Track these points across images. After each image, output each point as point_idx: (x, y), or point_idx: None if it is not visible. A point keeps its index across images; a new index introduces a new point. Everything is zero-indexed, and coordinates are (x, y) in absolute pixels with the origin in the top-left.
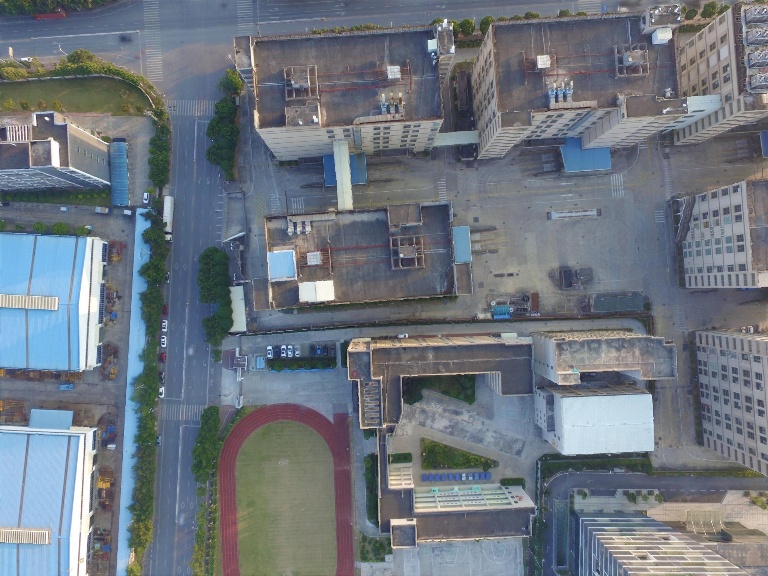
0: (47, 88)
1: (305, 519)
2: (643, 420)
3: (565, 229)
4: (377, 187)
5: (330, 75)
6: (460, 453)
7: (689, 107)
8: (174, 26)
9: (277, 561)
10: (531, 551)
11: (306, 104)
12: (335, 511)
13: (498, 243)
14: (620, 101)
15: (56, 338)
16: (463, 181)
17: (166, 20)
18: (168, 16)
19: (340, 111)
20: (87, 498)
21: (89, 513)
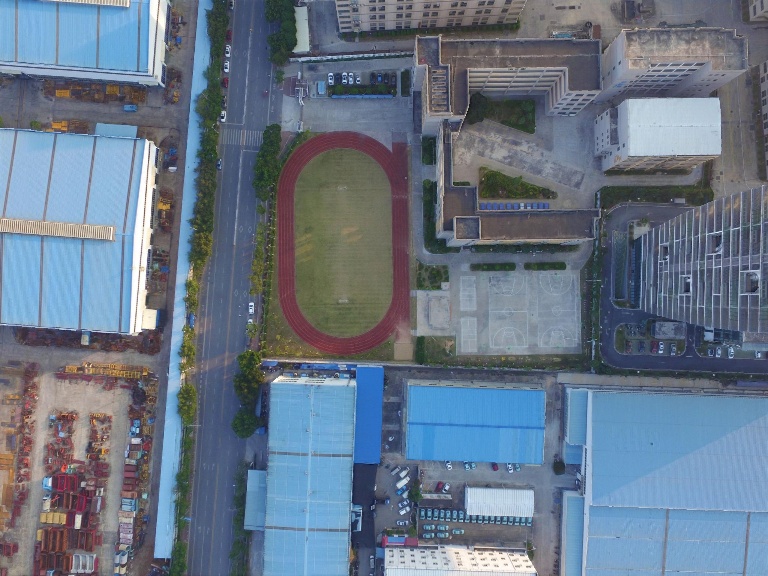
0: None
1: (362, 246)
2: (710, 122)
3: None
4: None
5: None
6: (520, 177)
7: None
8: None
9: (333, 287)
10: (589, 280)
11: None
12: (392, 240)
13: None
14: None
15: (126, 37)
16: None
17: None
18: None
19: None
20: (149, 211)
21: (150, 228)
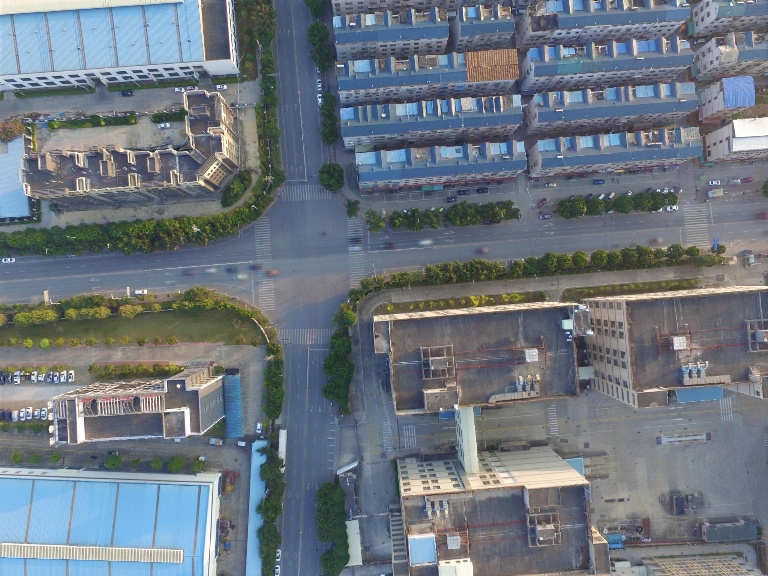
0: (160, 319)
1: None
2: None
3: (675, 453)
4: (488, 414)
5: (465, 353)
6: None
7: None
8: (285, 255)
9: None
10: None
11: (445, 388)
12: None
13: (608, 468)
14: (754, 378)
15: None
16: (573, 407)
17: (278, 250)
18: (279, 245)
19: (475, 388)
20: None
21: None
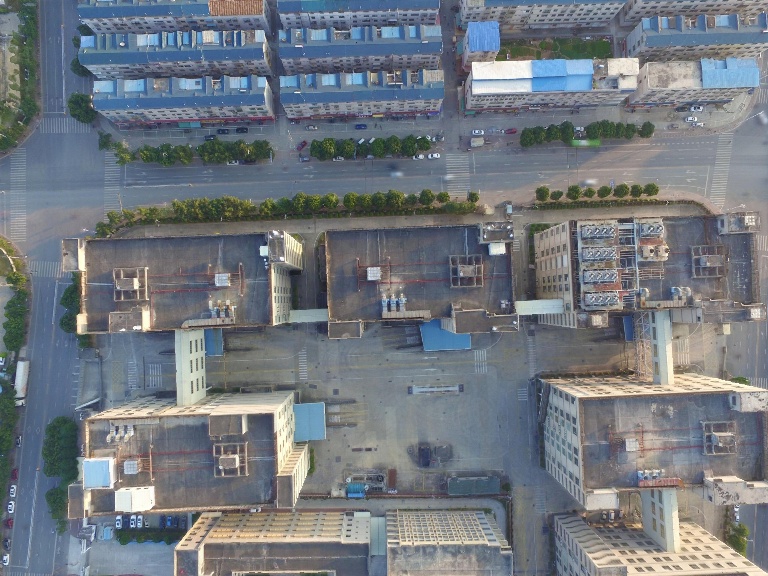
0: None
1: None
2: None
3: (426, 404)
4: (236, 356)
5: (161, 276)
6: None
7: (531, 311)
8: (40, 187)
9: None
10: None
11: (131, 309)
12: None
13: (357, 416)
14: (452, 313)
15: None
16: (324, 352)
17: (32, 181)
18: (35, 177)
19: (170, 312)
20: None
21: None
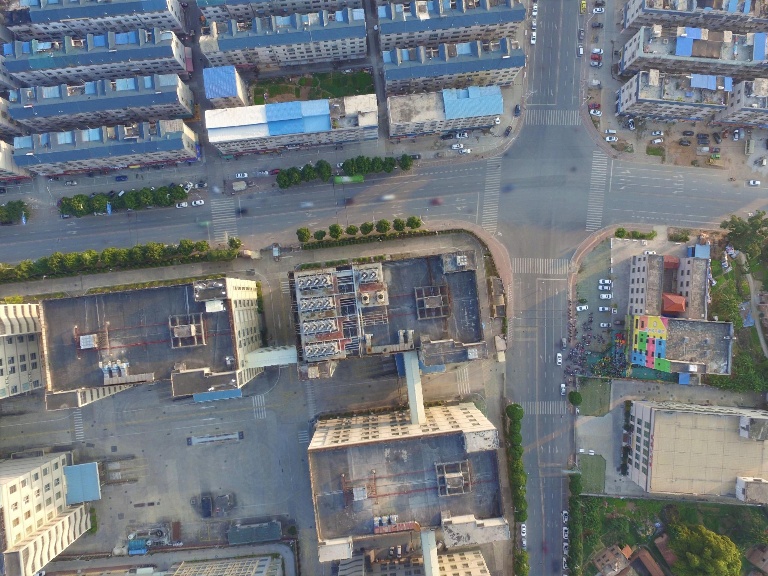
0: None
1: None
2: None
3: (206, 454)
4: (10, 420)
5: None
6: None
7: (268, 363)
8: None
9: None
10: None
11: None
12: None
13: (138, 472)
14: None
15: None
16: (99, 410)
17: None
18: None
19: None
20: None
21: None
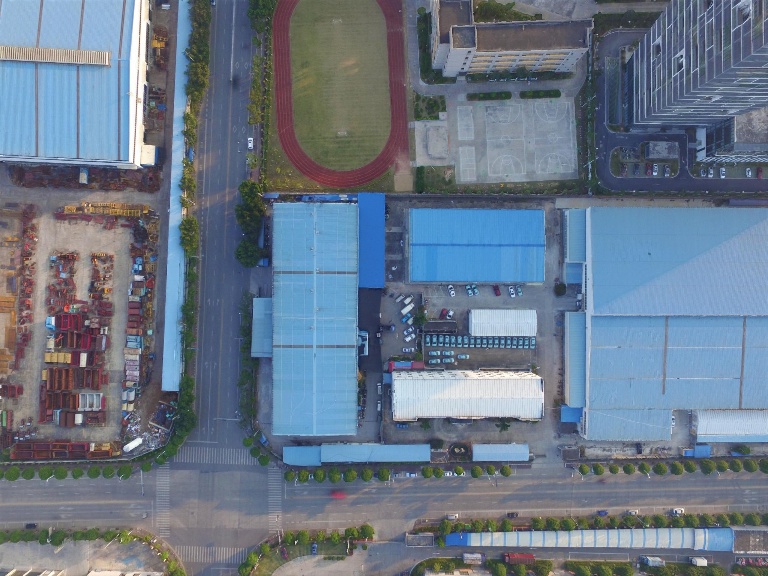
0: None
1: (359, 80)
2: None
3: None
4: None
5: None
6: (513, 3)
7: None
8: None
9: (332, 121)
10: (584, 104)
11: None
12: (388, 73)
13: None
14: None
15: None
16: None
17: None
18: None
19: None
20: (143, 45)
21: None
